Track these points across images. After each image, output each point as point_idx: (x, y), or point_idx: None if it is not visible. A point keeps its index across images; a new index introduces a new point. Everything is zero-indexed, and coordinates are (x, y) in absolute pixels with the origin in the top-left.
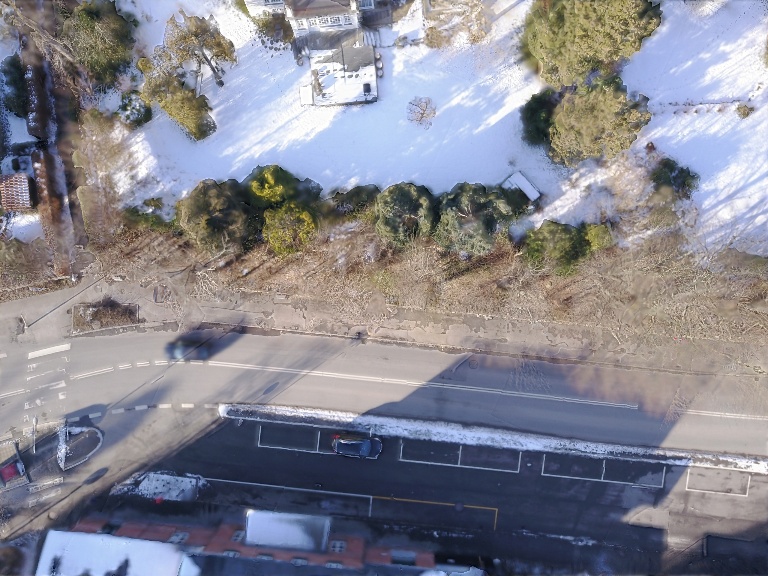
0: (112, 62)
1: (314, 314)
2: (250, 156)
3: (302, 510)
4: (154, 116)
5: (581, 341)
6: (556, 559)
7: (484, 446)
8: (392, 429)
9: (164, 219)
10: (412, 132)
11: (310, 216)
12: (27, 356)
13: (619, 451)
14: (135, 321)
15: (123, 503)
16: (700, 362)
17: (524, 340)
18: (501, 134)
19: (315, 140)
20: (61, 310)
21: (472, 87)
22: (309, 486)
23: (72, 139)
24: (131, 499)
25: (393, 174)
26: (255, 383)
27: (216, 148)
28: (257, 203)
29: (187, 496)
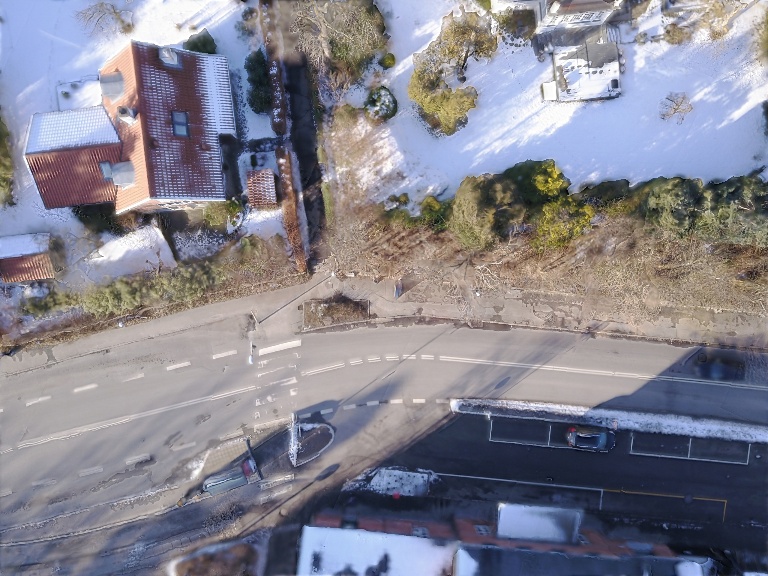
0: (364, 58)
1: (595, 307)
2: (490, 152)
3: (533, 504)
4: (397, 112)
5: None
6: None
7: (713, 438)
8: (623, 422)
9: (409, 214)
10: (655, 127)
11: (591, 210)
12: (258, 353)
13: None
14: (366, 317)
15: (355, 499)
16: None
17: (753, 333)
18: (744, 129)
19: (555, 136)
20: (292, 306)
21: (715, 83)
22: (540, 480)
23: (307, 135)
24: (363, 495)
25: (635, 169)
26: (486, 378)
27: (457, 144)
28: (529, 197)
29: (419, 491)
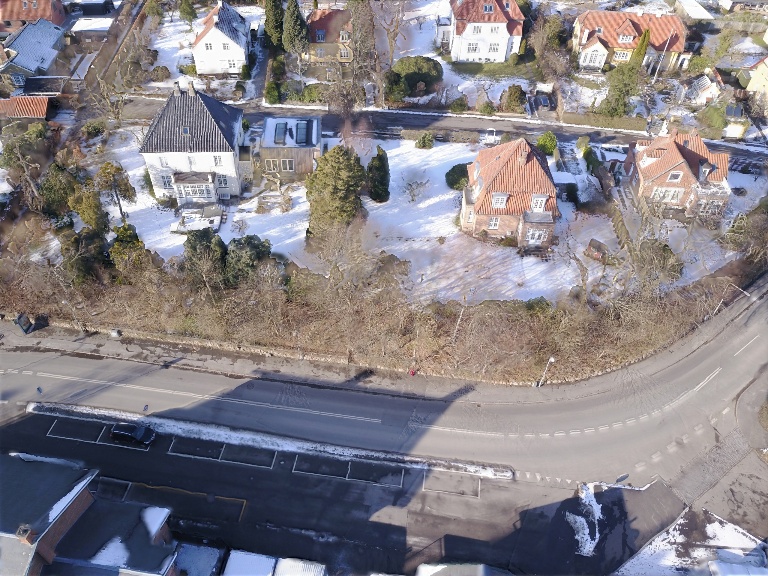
0: (61, 202)
1: (124, 289)
2: None
3: None
4: None
5: (339, 374)
6: (294, 552)
7: (245, 446)
8: (169, 427)
9: None
10: None
11: None
12: None
13: (363, 454)
14: None
15: None
16: (432, 392)
17: (294, 372)
18: (291, 247)
19: (172, 249)
20: None
21: (278, 228)
22: None
23: None
24: None
25: None
26: (67, 389)
27: None
28: None
29: None
